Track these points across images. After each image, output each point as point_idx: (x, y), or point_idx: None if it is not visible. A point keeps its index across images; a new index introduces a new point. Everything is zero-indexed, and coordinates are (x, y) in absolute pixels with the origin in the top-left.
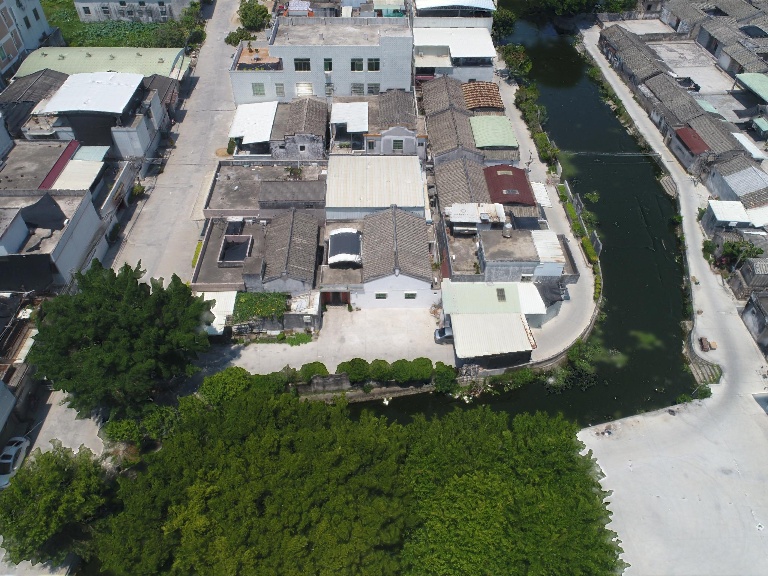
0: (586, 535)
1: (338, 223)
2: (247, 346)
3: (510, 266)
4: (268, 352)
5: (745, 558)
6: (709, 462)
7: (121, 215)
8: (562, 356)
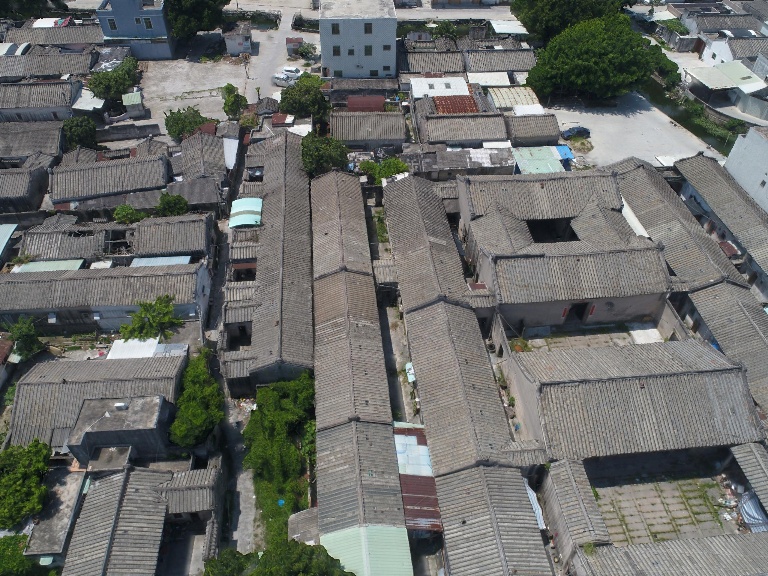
0: (591, 46)
1: (760, 36)
2: (650, 37)
3: (766, 64)
4: (651, 42)
5: (623, 153)
6: (679, 153)
7: (710, 1)
8: (726, 121)
